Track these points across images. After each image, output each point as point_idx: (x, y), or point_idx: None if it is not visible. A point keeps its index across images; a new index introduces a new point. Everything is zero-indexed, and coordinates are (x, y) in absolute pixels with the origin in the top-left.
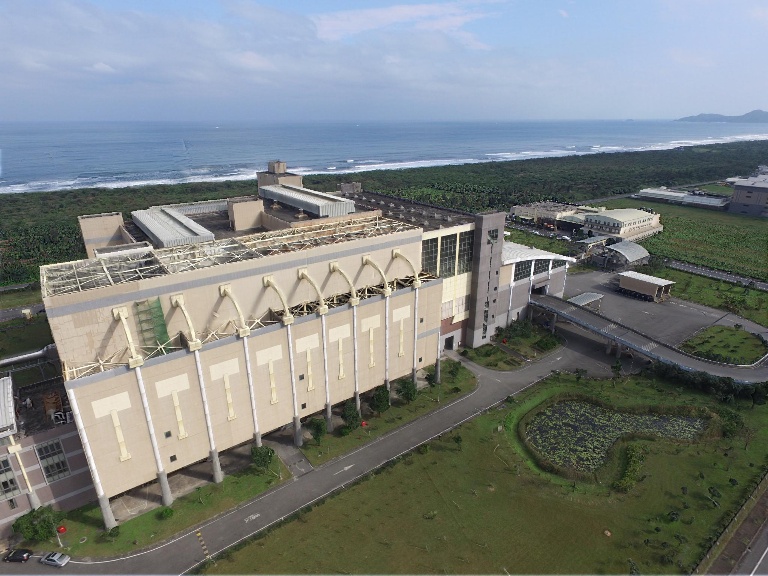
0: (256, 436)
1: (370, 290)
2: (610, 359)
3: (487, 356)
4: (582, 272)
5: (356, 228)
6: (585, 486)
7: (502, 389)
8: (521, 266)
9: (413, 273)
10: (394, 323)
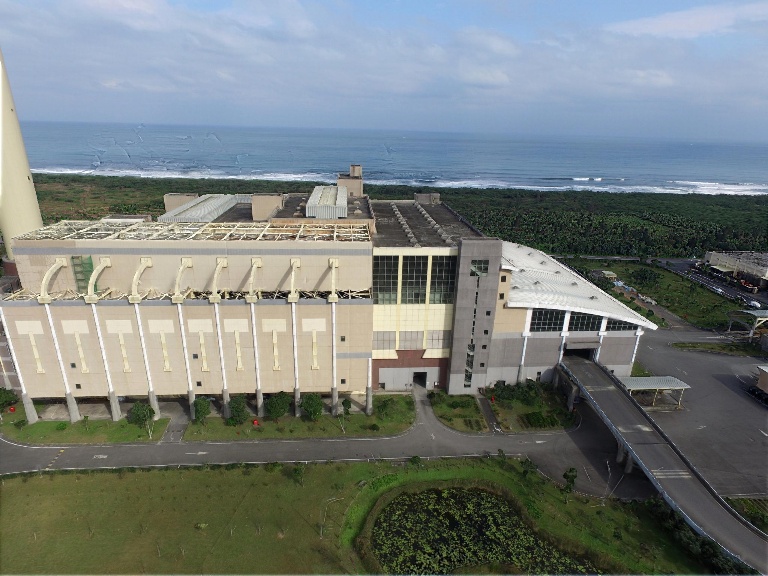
0: (149, 394)
1: (303, 295)
2: (612, 469)
3: (452, 407)
4: (724, 353)
5: (324, 232)
6: None
7: (425, 447)
8: (544, 315)
9: (358, 288)
10: (305, 332)
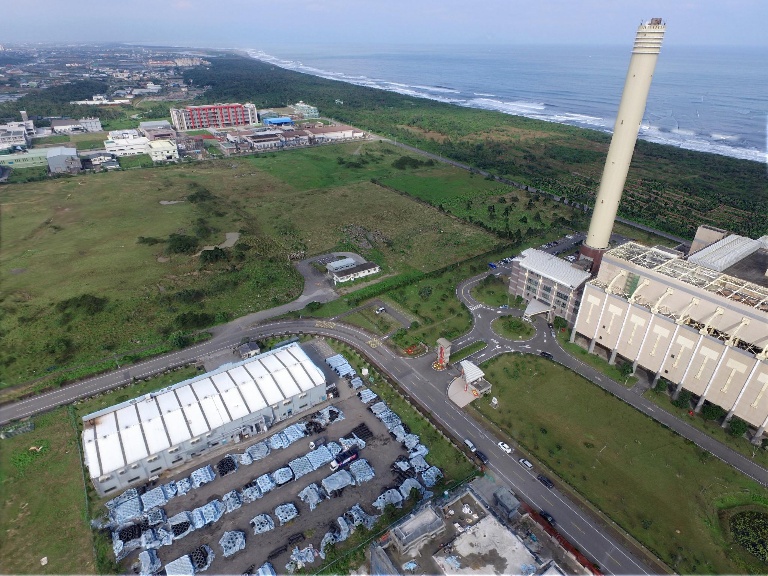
0: (635, 361)
1: None
2: None
3: None
4: None
5: None
6: (719, 534)
7: None
8: None
9: None
10: (758, 381)
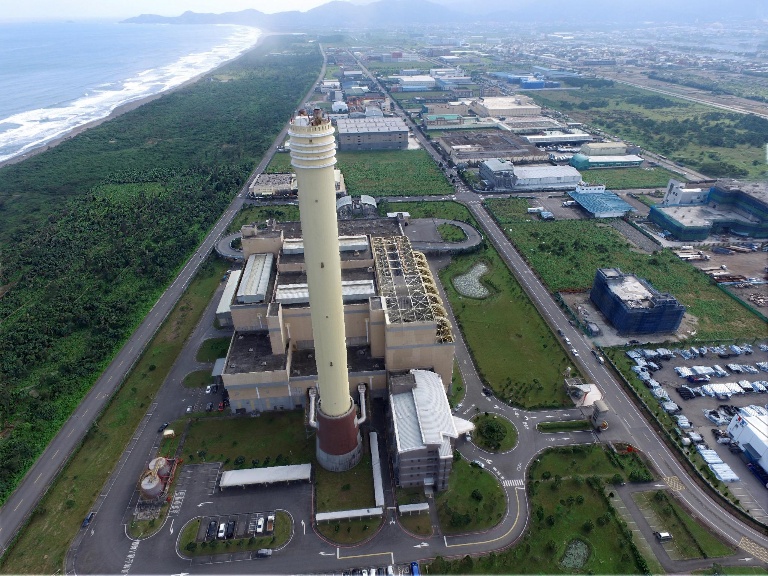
0: None
1: None
2: (439, 257)
3: None
4: None
5: None
6: None
7: None
8: None
9: None
10: None
